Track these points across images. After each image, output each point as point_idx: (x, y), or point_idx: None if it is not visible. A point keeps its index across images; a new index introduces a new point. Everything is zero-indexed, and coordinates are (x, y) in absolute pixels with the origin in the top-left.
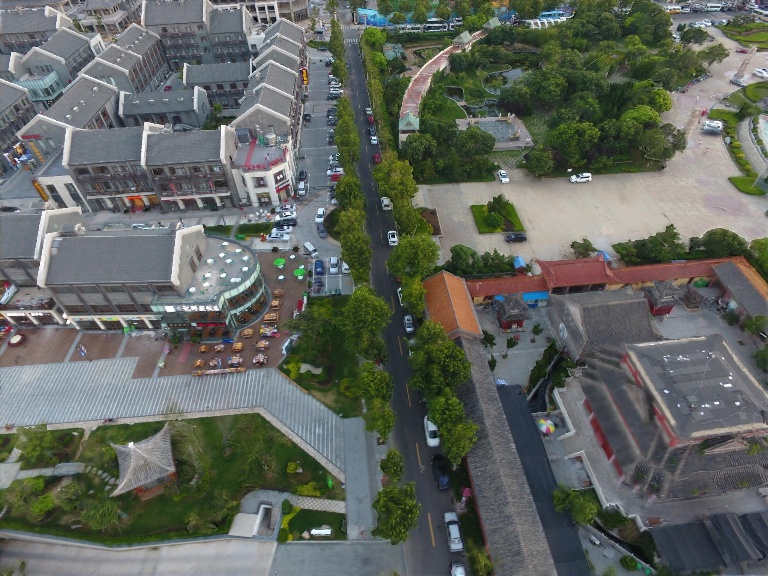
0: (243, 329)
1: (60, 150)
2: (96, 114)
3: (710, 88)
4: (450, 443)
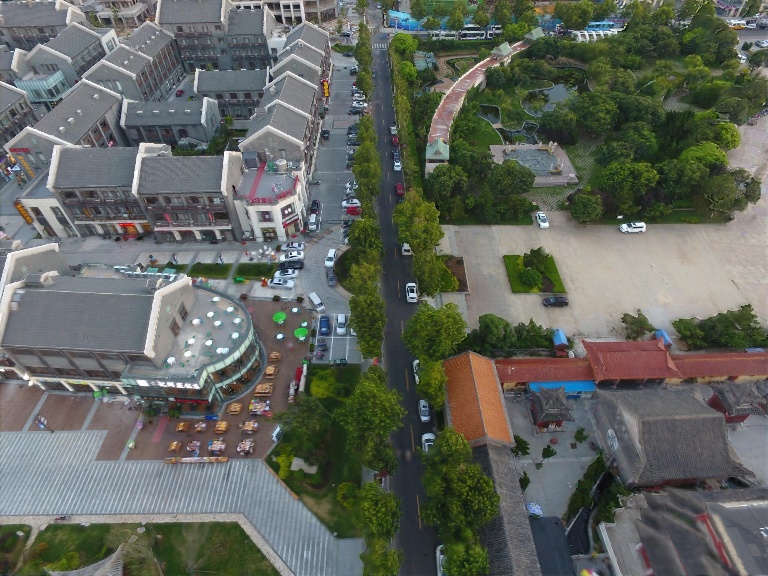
0: (230, 402)
1: None
2: (94, 126)
3: None
4: None
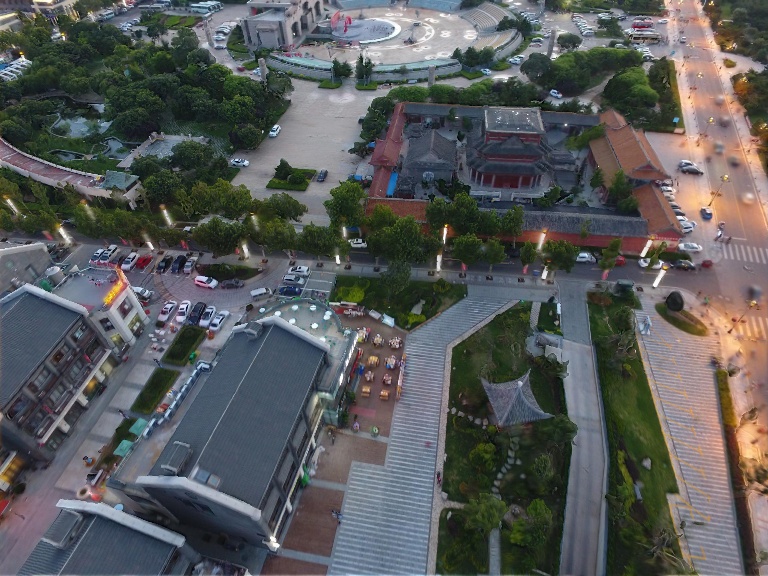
0: None
1: None
2: None
3: (215, 57)
4: (516, 226)
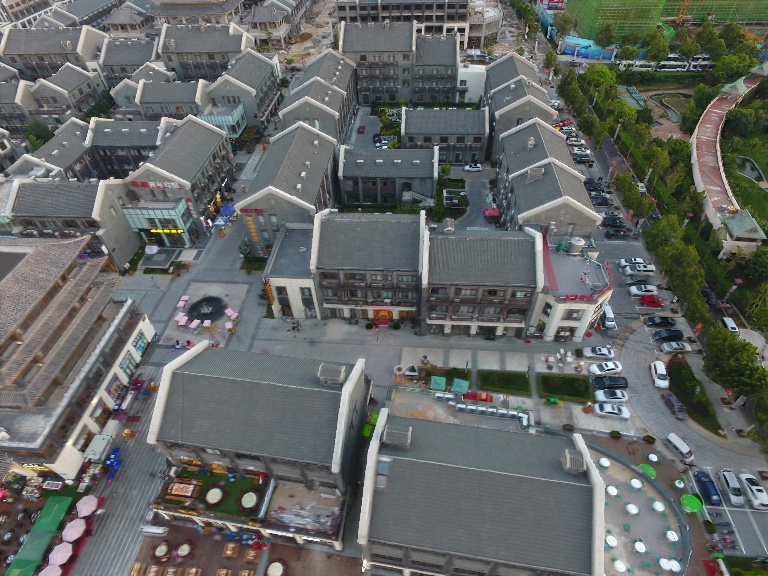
0: None
1: (284, 230)
2: (322, 180)
3: None
4: None
